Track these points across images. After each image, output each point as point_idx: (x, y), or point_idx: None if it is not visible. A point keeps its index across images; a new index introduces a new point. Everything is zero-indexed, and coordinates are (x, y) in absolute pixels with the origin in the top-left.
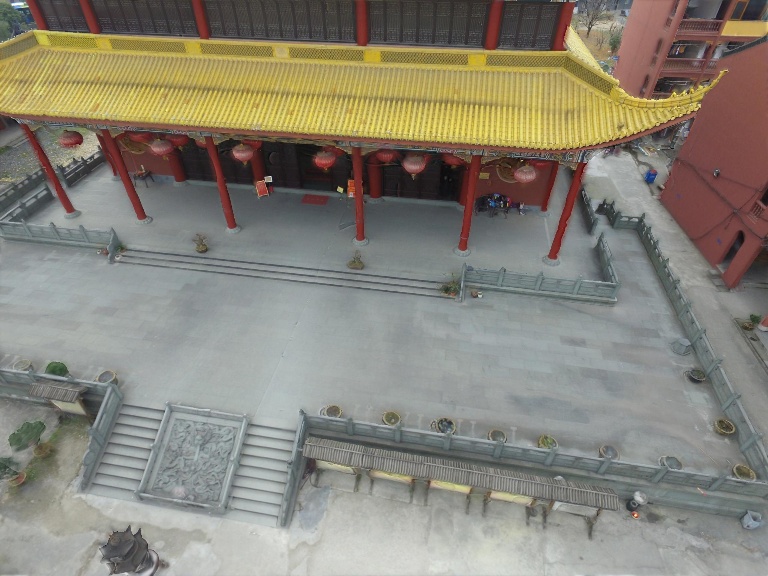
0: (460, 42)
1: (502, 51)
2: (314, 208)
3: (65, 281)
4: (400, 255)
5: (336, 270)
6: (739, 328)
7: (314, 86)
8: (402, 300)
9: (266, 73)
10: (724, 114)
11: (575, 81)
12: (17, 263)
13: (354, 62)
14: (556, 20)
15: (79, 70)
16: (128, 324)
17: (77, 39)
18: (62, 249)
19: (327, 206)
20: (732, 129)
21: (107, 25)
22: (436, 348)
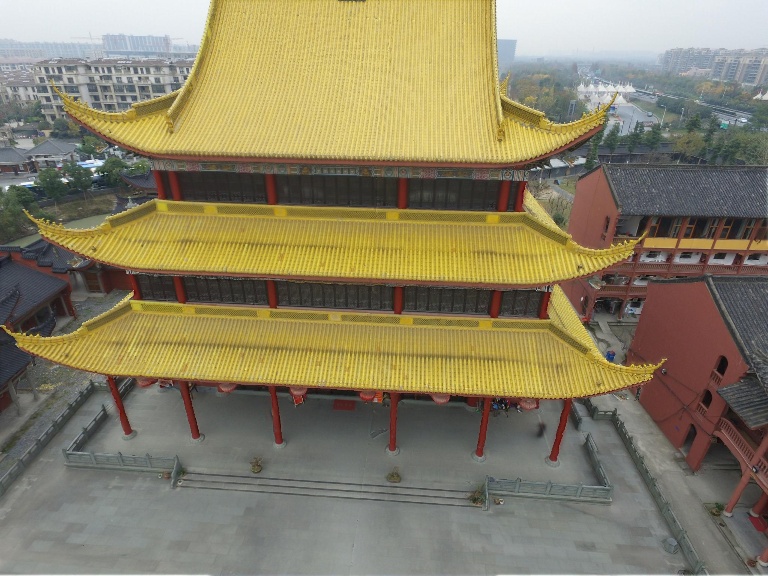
0: (472, 311)
1: (504, 319)
2: (345, 415)
3: (134, 513)
4: (428, 464)
5: (377, 484)
6: (709, 513)
7: (363, 344)
8: (438, 512)
9: (323, 333)
10: (660, 326)
11: (559, 340)
12: (84, 494)
13: (392, 324)
14: (540, 300)
15: (167, 331)
16: (203, 559)
17: (167, 307)
18: (124, 474)
19: (356, 412)
20: (669, 340)
21: (193, 297)
22: (477, 564)
